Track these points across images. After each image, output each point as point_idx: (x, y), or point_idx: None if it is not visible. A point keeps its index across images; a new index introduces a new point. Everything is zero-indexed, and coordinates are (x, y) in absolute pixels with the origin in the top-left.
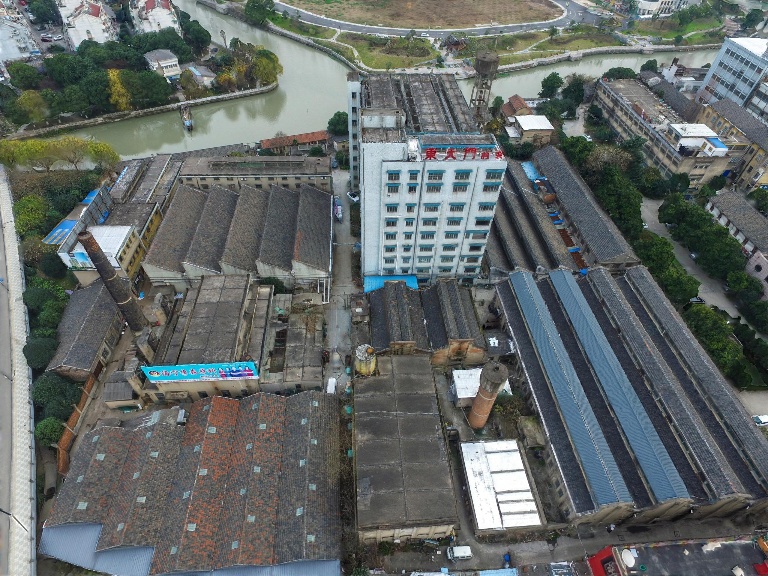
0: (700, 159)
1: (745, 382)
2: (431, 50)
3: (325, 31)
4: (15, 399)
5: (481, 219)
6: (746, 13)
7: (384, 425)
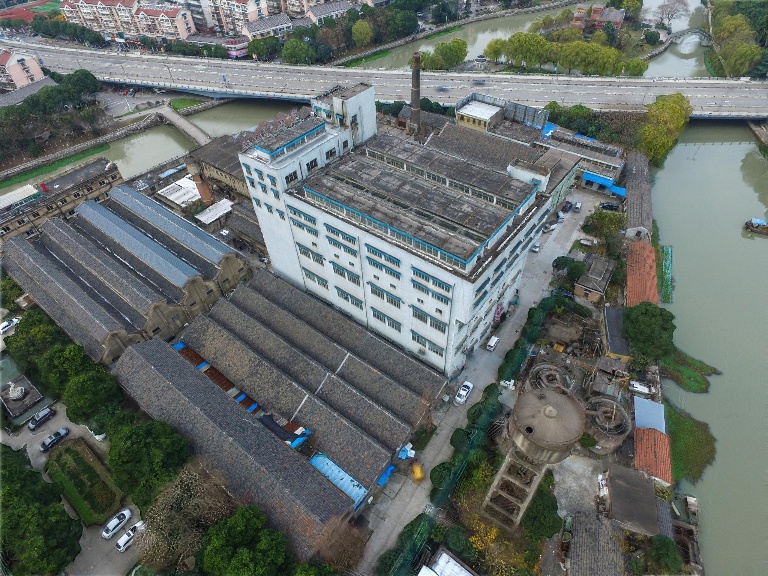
0: None
1: None
2: None
3: None
4: None
5: None
6: None
7: None
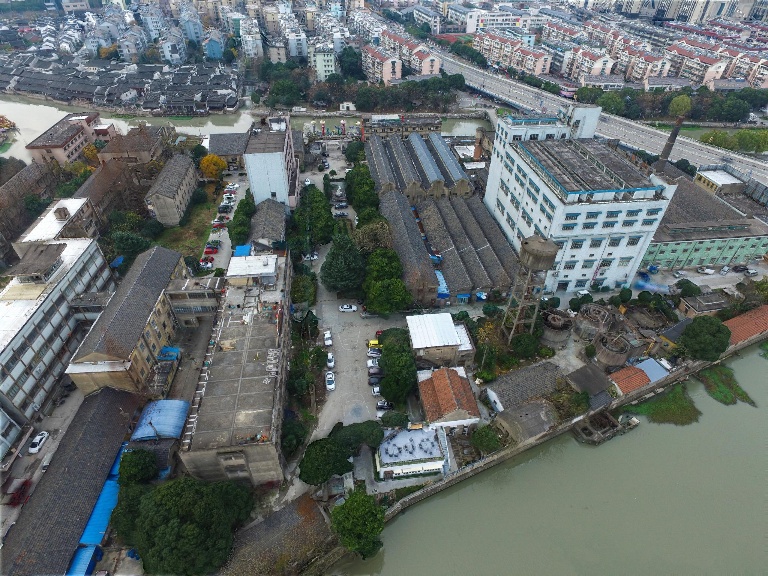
0: None
1: None
2: None
3: None
4: None
5: None
6: None
7: None
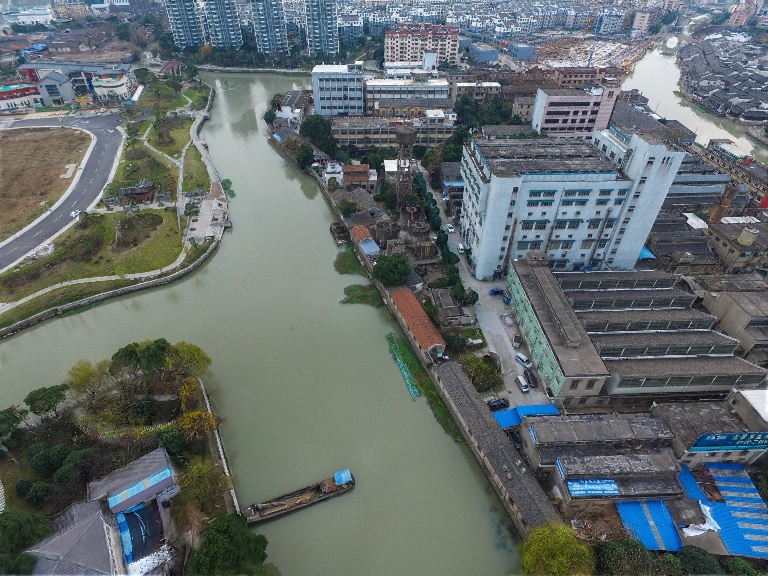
0: None
1: None
2: (139, 213)
3: None
4: None
5: None
6: None
7: None
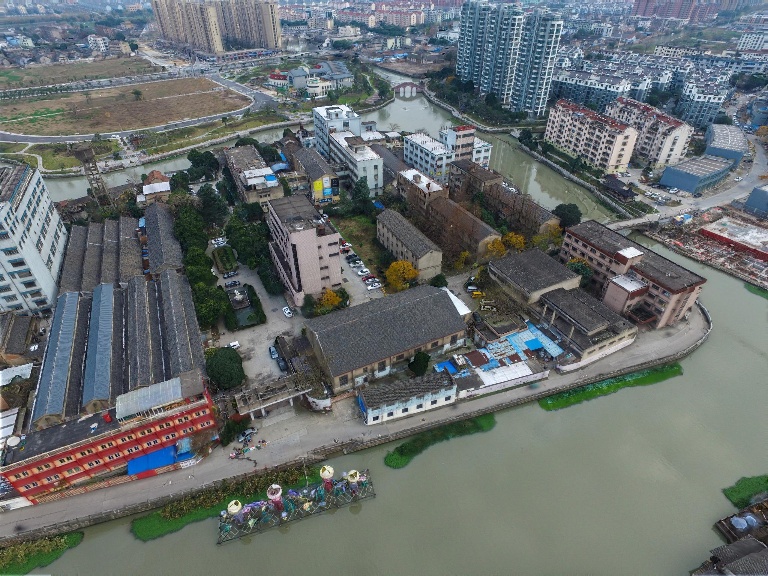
0: (260, 191)
1: (229, 325)
2: (114, 147)
3: (15, 146)
4: None
5: (14, 261)
6: (392, 86)
7: None
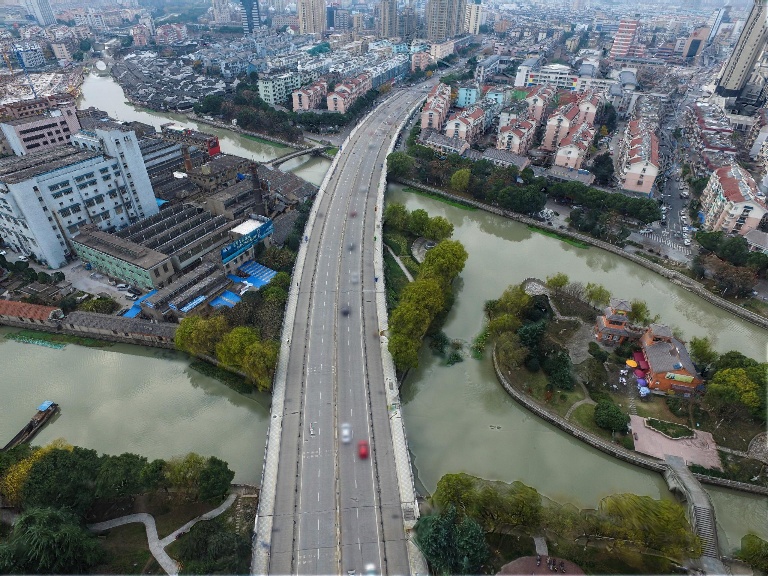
0: None
1: None
2: None
3: None
4: (316, 211)
5: None
6: None
7: (220, 166)
